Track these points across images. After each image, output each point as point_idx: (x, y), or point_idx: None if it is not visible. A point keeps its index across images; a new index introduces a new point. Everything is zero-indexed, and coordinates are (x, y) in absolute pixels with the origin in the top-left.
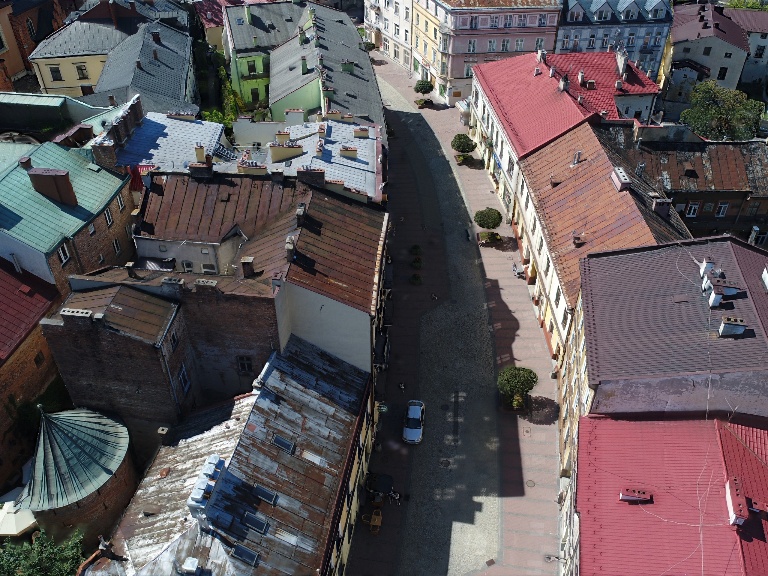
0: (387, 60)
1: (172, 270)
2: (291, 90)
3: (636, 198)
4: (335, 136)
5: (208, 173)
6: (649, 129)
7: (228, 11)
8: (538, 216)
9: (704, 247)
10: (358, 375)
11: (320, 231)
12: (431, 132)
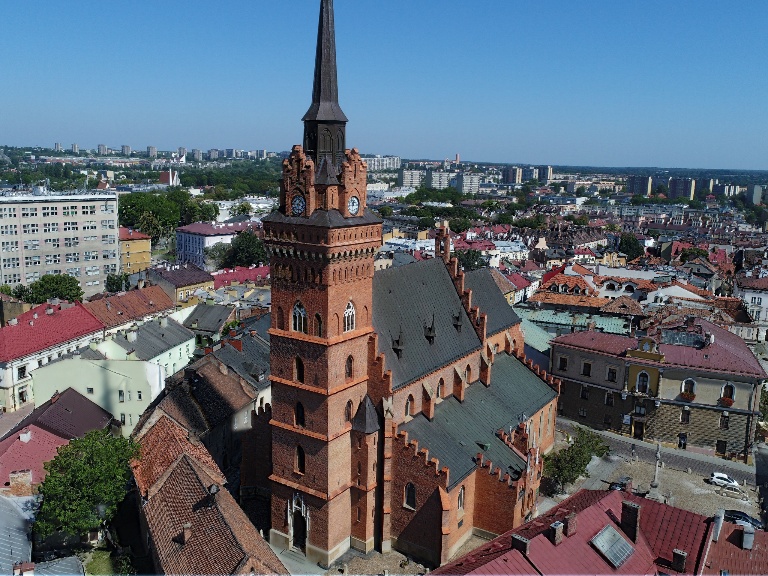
0: None
1: None
2: (181, 328)
3: None
4: None
5: None
6: None
7: None
8: None
9: None
10: None
11: None
12: None
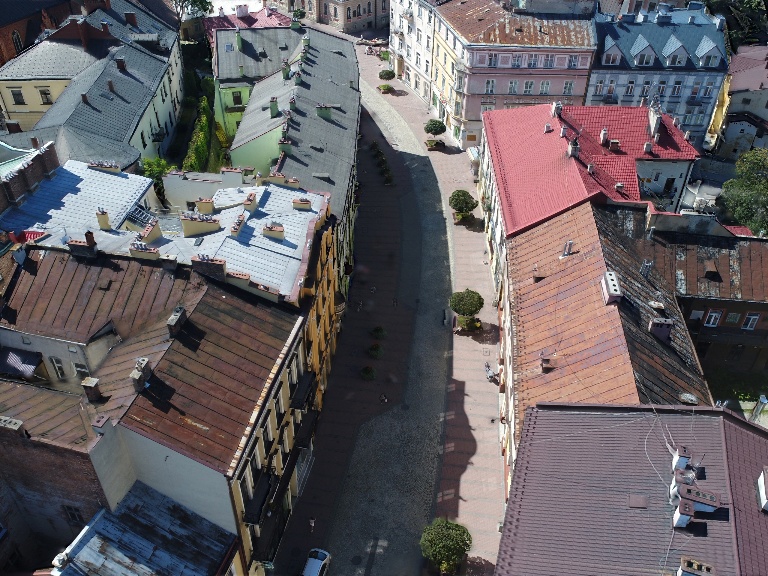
0: (408, 90)
1: (35, 367)
2: (255, 135)
3: (627, 315)
4: (270, 206)
5: (90, 252)
6: (665, 217)
7: (218, 35)
8: (510, 318)
9: (687, 420)
10: (219, 538)
11: (198, 344)
12: (435, 181)
